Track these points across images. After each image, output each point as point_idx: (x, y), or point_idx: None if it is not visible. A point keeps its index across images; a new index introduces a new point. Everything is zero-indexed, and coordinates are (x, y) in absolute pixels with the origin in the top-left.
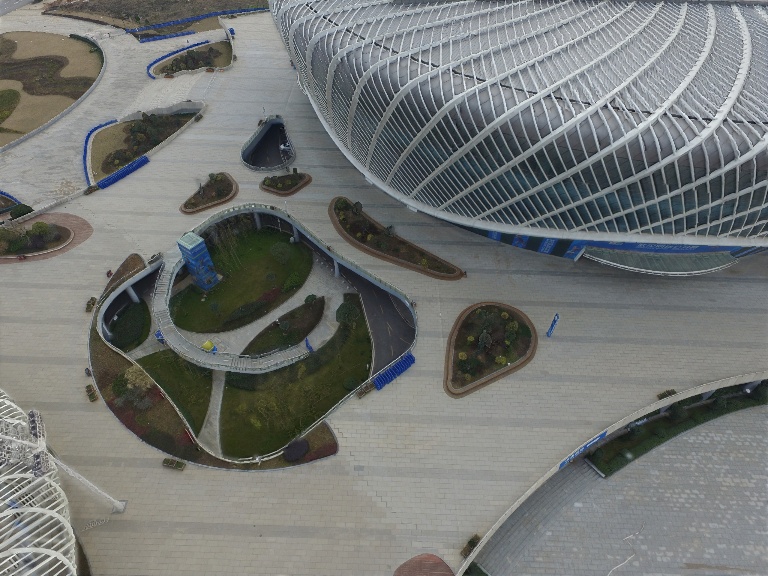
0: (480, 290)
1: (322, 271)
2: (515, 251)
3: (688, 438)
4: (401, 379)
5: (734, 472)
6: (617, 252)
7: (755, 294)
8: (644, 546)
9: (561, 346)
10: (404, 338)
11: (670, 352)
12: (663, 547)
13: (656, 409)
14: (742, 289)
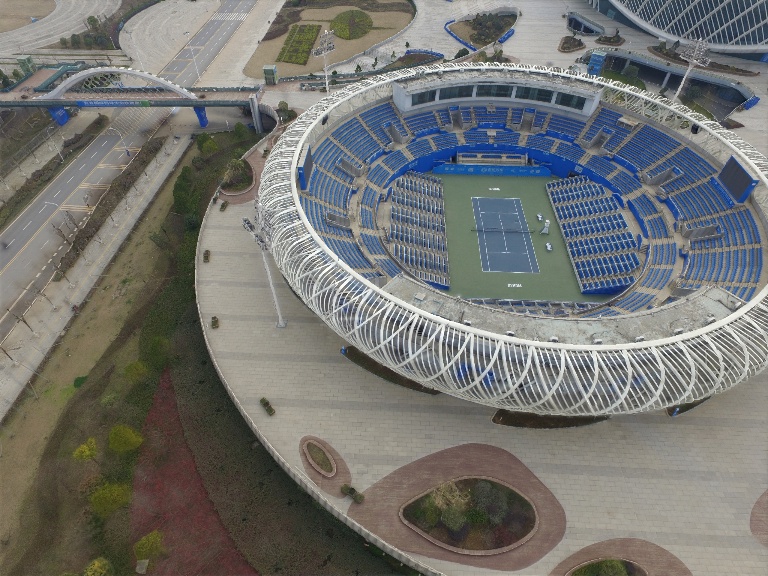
0: None
1: (652, 85)
2: None
3: None
4: (756, 107)
5: None
6: None
7: None
8: None
9: None
10: (725, 109)
11: None
12: None
13: None
14: None
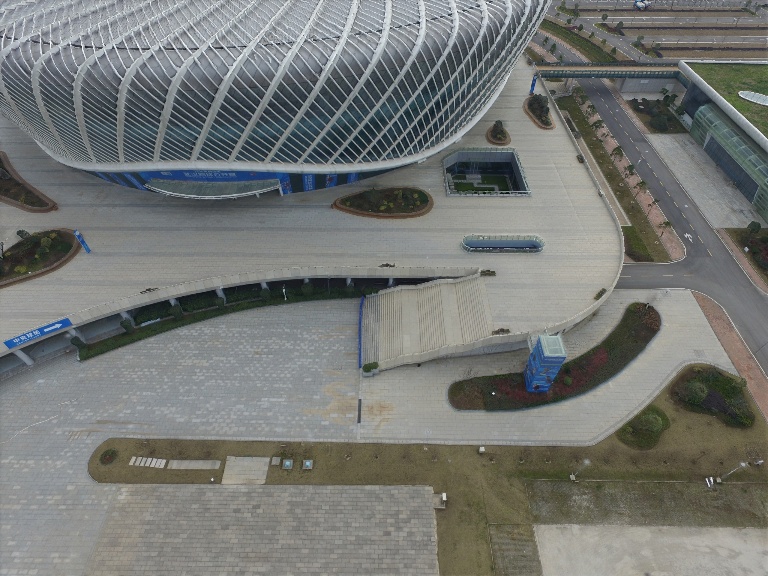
0: (59, 219)
1: None
2: (120, 189)
3: (181, 331)
4: None
5: (199, 355)
6: (176, 182)
7: (306, 217)
8: (72, 409)
9: (92, 259)
10: None
11: (185, 262)
12: (88, 409)
13: (139, 305)
14: (298, 213)
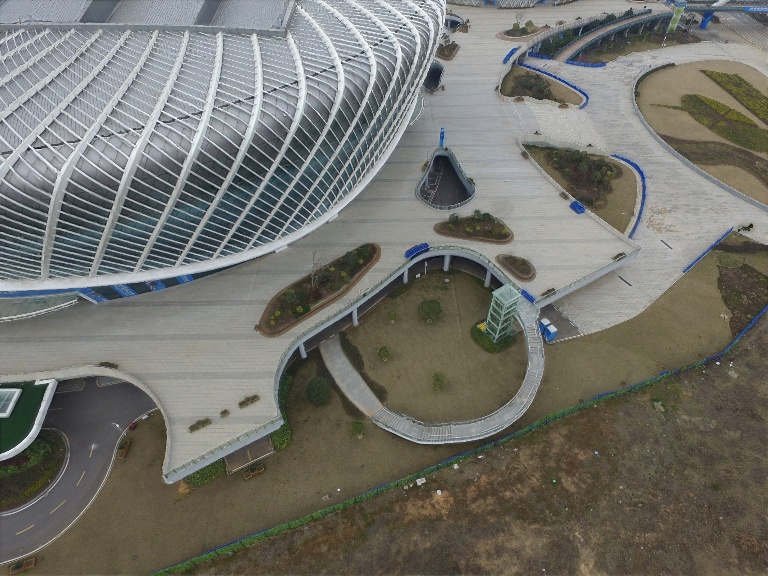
0: None
1: None
2: None
3: None
4: None
5: None
6: None
7: None
8: None
9: None
10: None
11: None
12: None
13: None
14: None
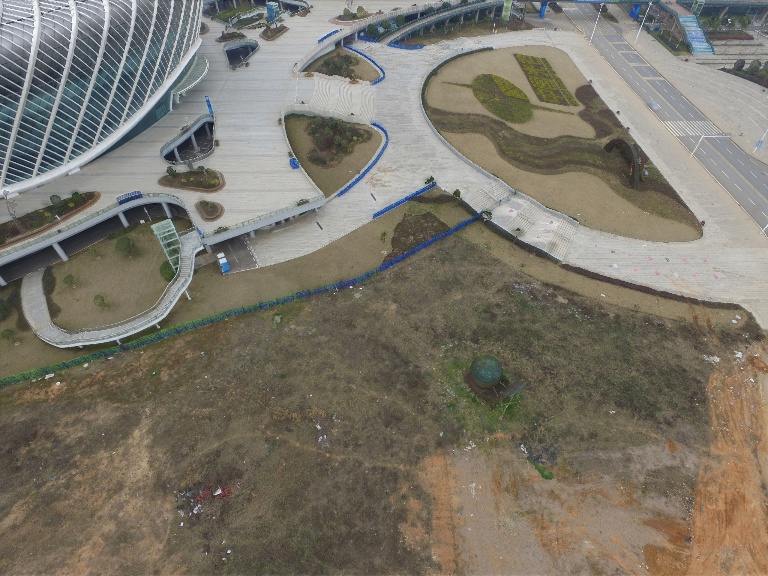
0: None
1: None
2: None
3: None
4: None
5: None
6: None
7: None
8: None
9: None
10: None
11: None
12: None
13: None
14: None
